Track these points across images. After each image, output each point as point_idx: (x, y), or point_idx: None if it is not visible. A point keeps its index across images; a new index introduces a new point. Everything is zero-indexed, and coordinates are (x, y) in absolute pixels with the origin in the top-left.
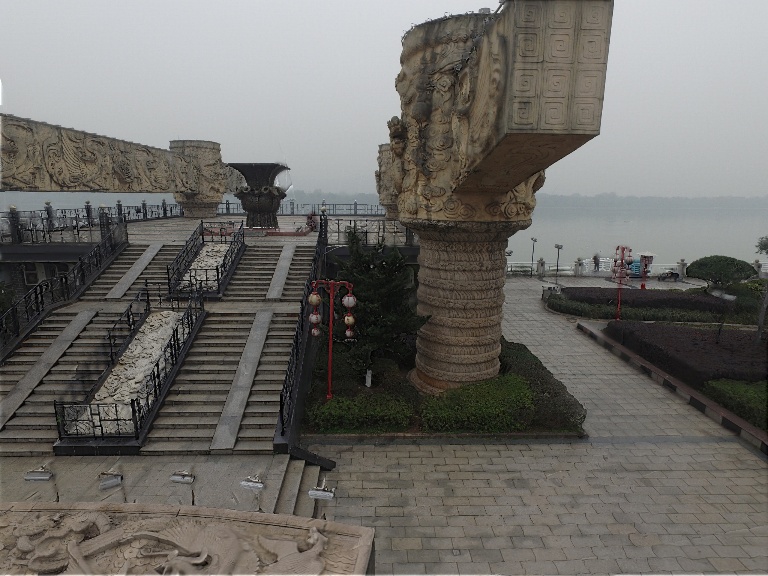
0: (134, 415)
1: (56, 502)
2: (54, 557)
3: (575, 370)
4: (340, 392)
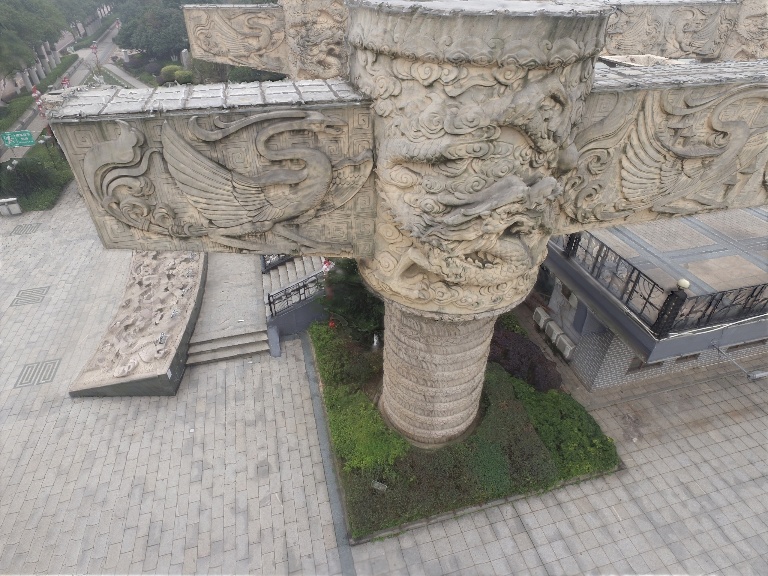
0: (263, 256)
1: (202, 270)
2: (173, 286)
3: (562, 568)
4: (346, 329)
